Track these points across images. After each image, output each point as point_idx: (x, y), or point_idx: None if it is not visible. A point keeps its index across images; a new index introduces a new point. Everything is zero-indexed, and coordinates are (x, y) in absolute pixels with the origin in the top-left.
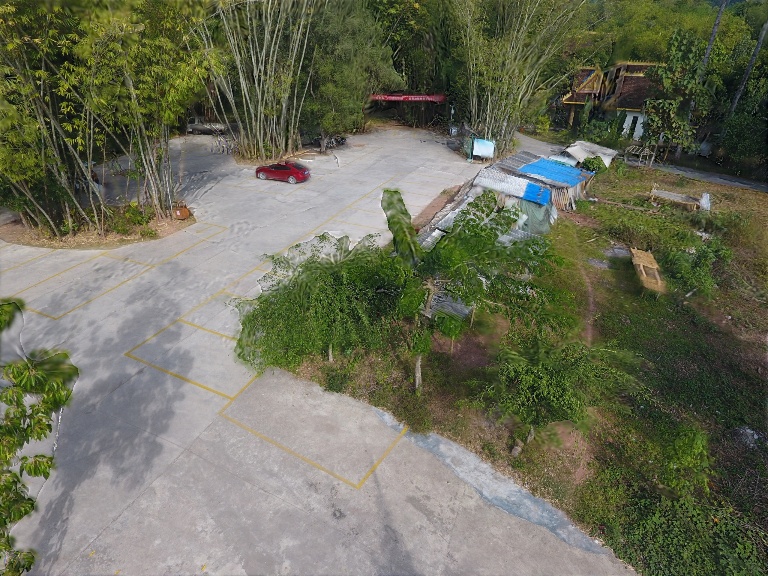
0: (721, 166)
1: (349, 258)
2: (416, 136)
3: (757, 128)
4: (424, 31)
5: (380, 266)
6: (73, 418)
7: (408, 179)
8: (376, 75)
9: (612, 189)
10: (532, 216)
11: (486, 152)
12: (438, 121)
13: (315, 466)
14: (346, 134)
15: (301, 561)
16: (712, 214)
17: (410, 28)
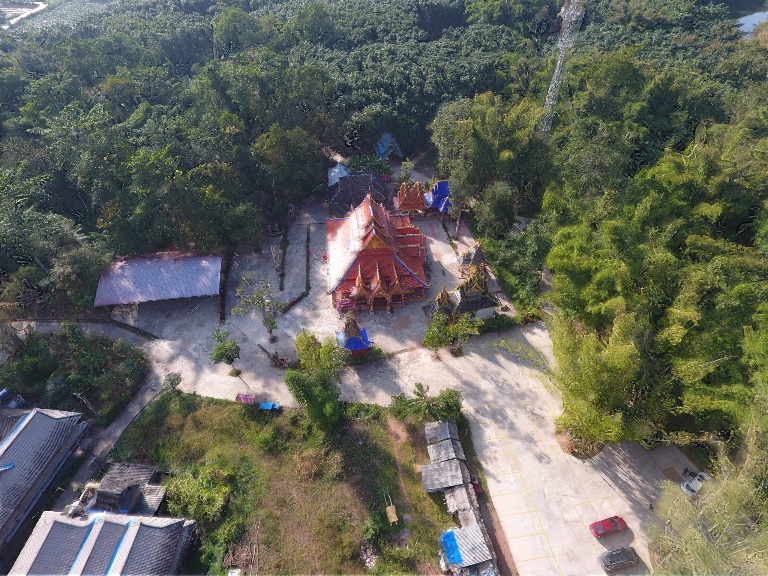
0: None
1: None
2: None
3: None
4: None
5: None
6: (473, 378)
7: None
8: None
9: None
10: None
11: None
12: None
13: None
14: None
15: (419, 382)
16: None
17: None
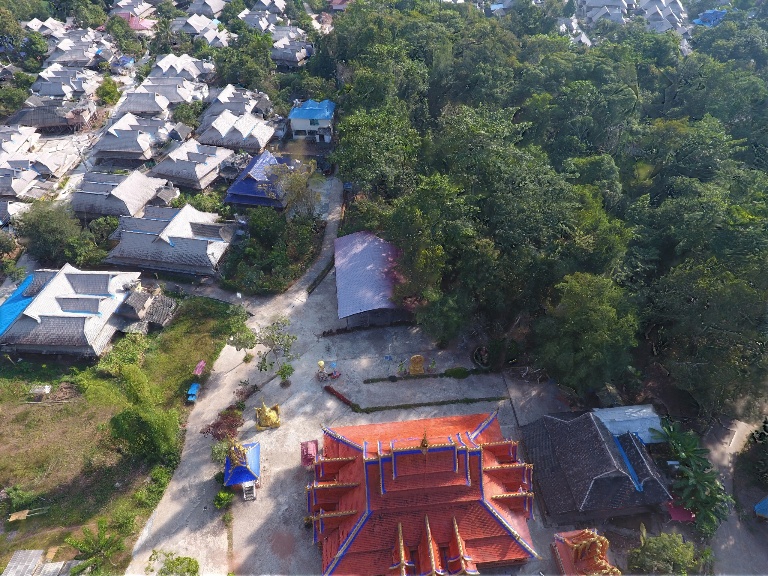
0: None
1: None
2: None
3: None
4: None
5: (96, 570)
6: None
7: None
8: None
9: None
10: None
11: None
12: None
13: (149, 575)
14: None
15: None
16: None
17: None
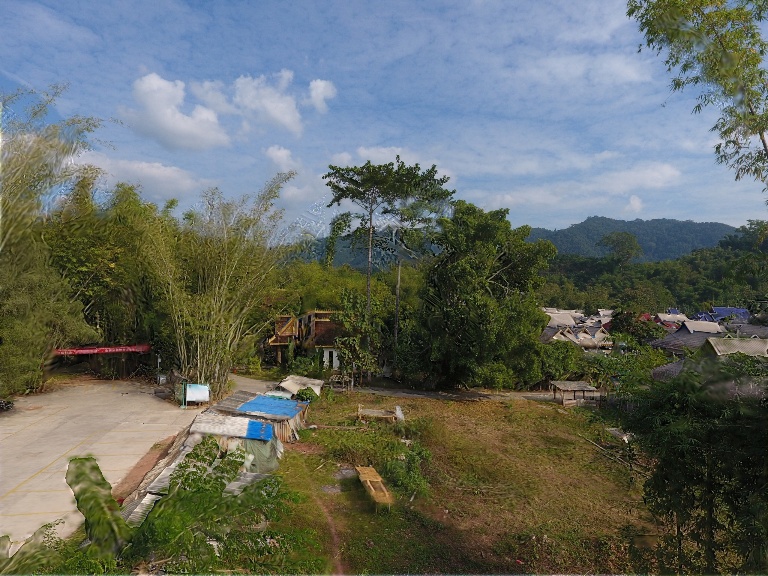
0: (401, 383)
1: (8, 570)
2: (116, 389)
3: (415, 353)
4: (122, 287)
5: (63, 568)
6: None
7: (106, 439)
8: (61, 329)
9: (327, 414)
10: (258, 454)
11: (201, 396)
12: (143, 371)
13: None
14: (14, 397)
15: None
16: (407, 422)
17: (105, 284)
